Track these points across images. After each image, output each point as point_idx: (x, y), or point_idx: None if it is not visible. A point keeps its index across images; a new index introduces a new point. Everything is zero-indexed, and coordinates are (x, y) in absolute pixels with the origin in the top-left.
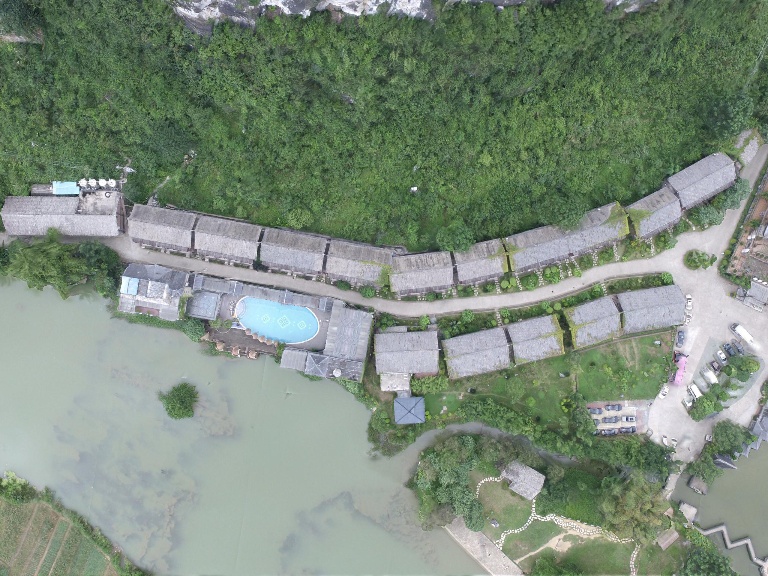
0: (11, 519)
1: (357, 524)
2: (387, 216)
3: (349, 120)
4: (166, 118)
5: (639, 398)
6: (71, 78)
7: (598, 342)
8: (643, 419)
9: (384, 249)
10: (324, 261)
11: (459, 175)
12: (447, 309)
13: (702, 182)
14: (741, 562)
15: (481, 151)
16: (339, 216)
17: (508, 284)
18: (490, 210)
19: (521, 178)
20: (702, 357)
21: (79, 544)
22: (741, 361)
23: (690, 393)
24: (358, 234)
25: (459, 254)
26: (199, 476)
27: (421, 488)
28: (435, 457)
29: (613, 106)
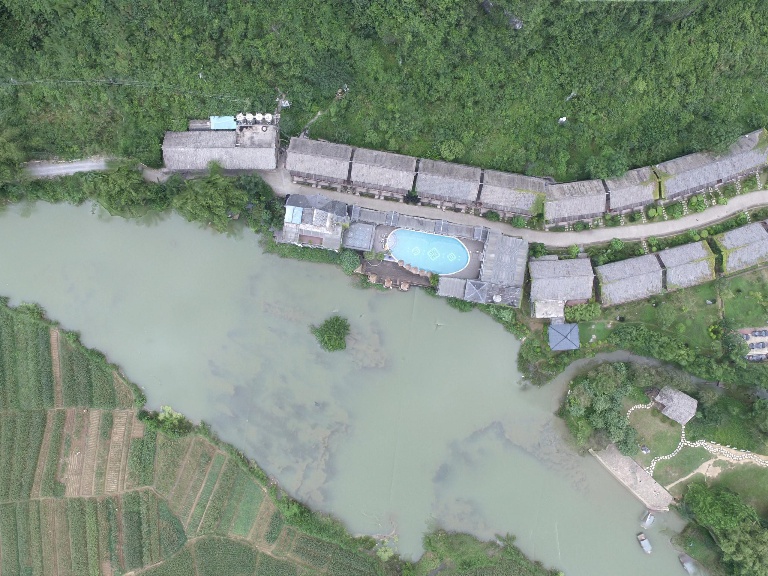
0: (169, 452)
1: (508, 453)
2: (536, 147)
3: (508, 48)
4: (328, 49)
5: None
6: (243, 7)
7: None
8: None
9: (537, 178)
10: (479, 190)
11: (610, 104)
12: (594, 239)
13: None
14: None
15: (635, 78)
16: (488, 148)
17: (656, 212)
18: (639, 139)
19: (672, 105)
20: None
21: (236, 476)
22: None
23: None
24: (508, 165)
25: (611, 181)
26: (352, 408)
27: (574, 415)
28: (589, 383)
29: (761, 33)
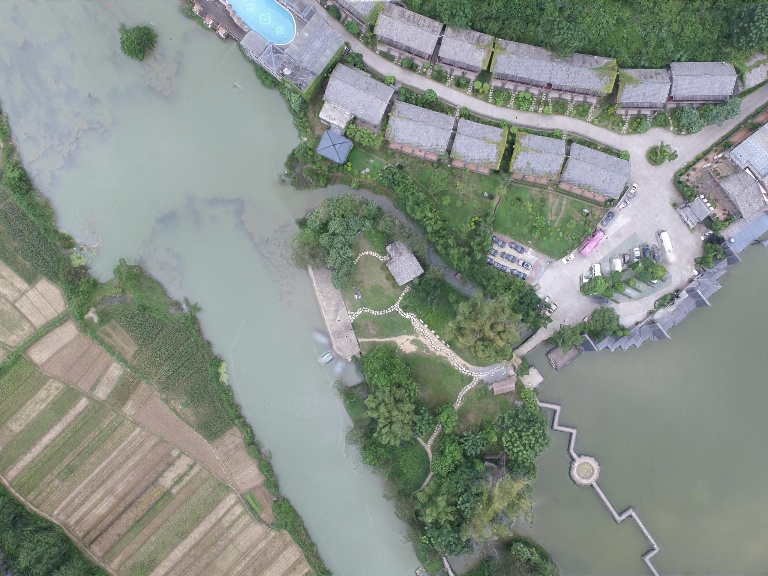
0: None
1: (236, 233)
2: None
3: None
4: None
5: (544, 252)
6: None
7: (533, 175)
8: (538, 273)
9: None
10: None
11: None
12: (415, 83)
13: (699, 79)
14: (558, 447)
15: None
16: None
17: (481, 86)
18: (499, 8)
19: None
20: (619, 246)
21: None
22: (651, 263)
23: (591, 271)
24: None
25: (451, 29)
26: (119, 117)
27: (309, 225)
28: None
29: None
